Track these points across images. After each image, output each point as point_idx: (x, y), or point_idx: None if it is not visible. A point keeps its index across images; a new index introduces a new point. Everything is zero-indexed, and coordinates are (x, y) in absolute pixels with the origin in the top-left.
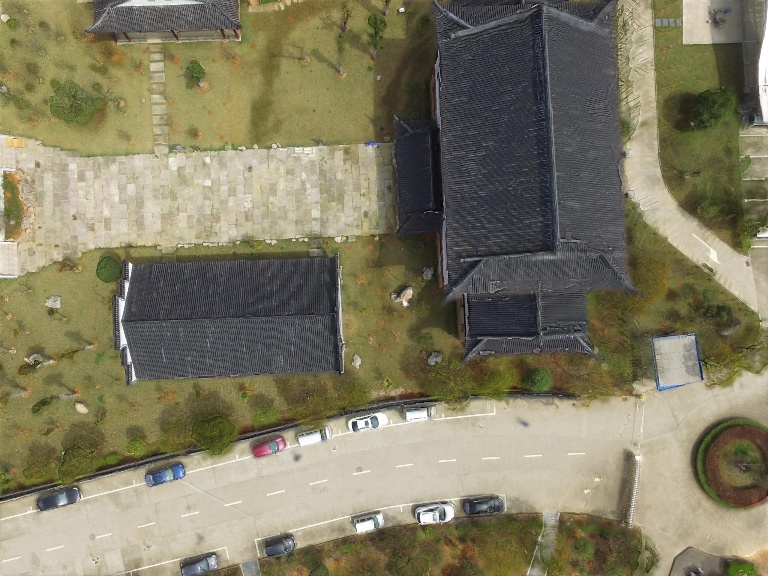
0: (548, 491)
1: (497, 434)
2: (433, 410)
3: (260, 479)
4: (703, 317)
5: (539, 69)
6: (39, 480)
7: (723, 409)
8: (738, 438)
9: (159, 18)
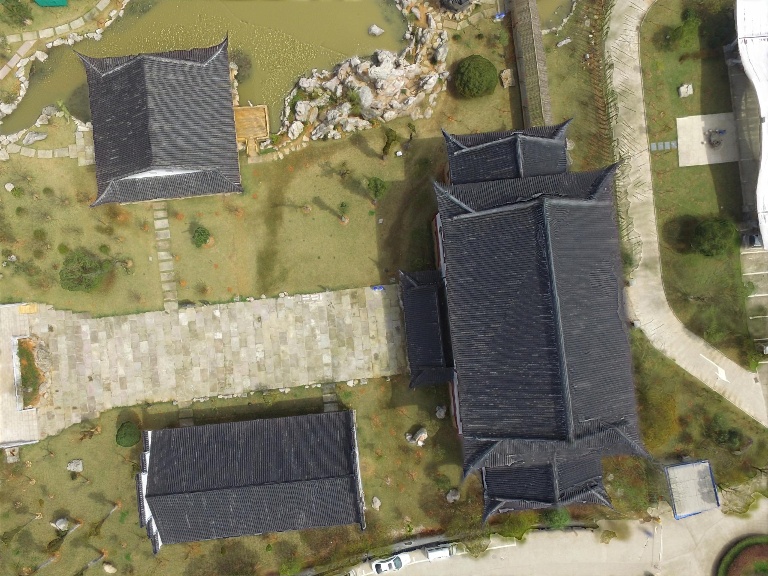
0: None
1: (519, 565)
2: (454, 548)
3: None
4: (715, 441)
5: (543, 258)
6: None
7: (740, 526)
8: (757, 556)
9: (162, 187)
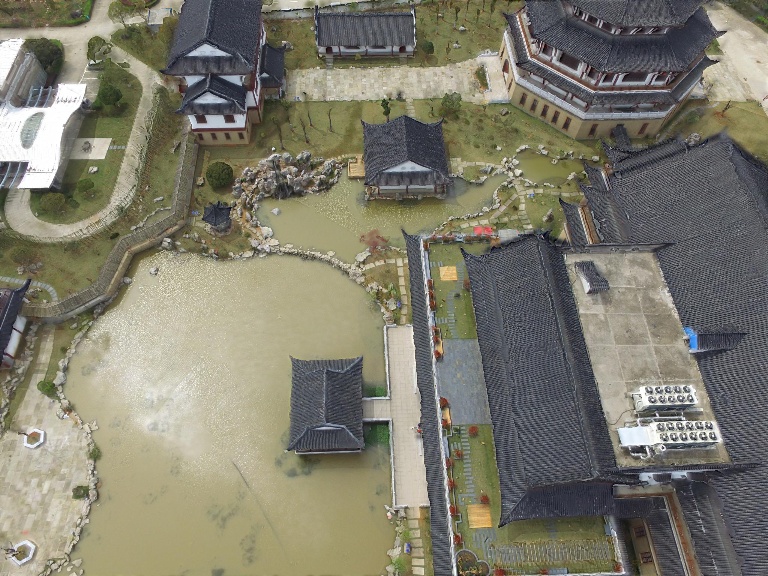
0: None
1: None
2: None
3: None
4: None
5: None
6: None
7: None
8: None
9: None
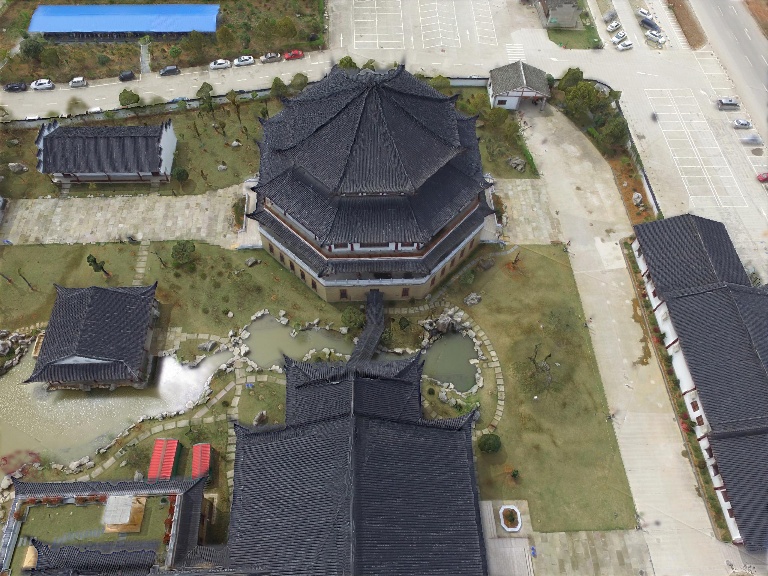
0: None
1: None
2: None
3: None
4: None
5: None
6: (242, 100)
7: None
8: None
9: None
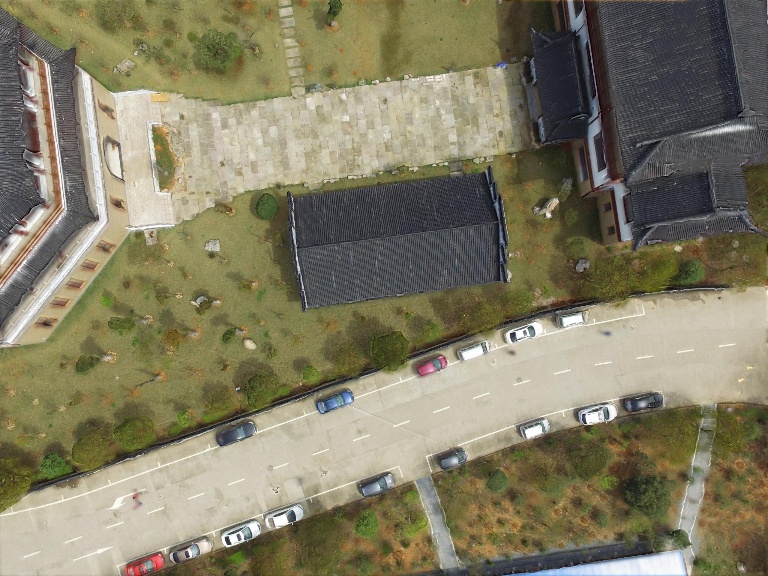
0: (703, 384)
1: (649, 333)
2: (587, 315)
3: (425, 398)
4: None
5: None
6: (217, 417)
7: None
8: None
9: None
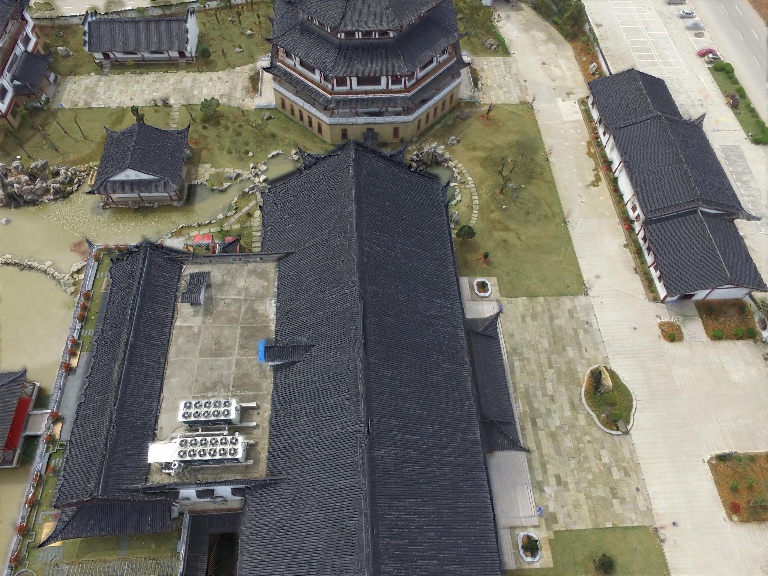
0: None
1: (41, 14)
2: None
3: (157, 4)
4: None
5: None
6: (253, 0)
7: None
8: None
9: None
